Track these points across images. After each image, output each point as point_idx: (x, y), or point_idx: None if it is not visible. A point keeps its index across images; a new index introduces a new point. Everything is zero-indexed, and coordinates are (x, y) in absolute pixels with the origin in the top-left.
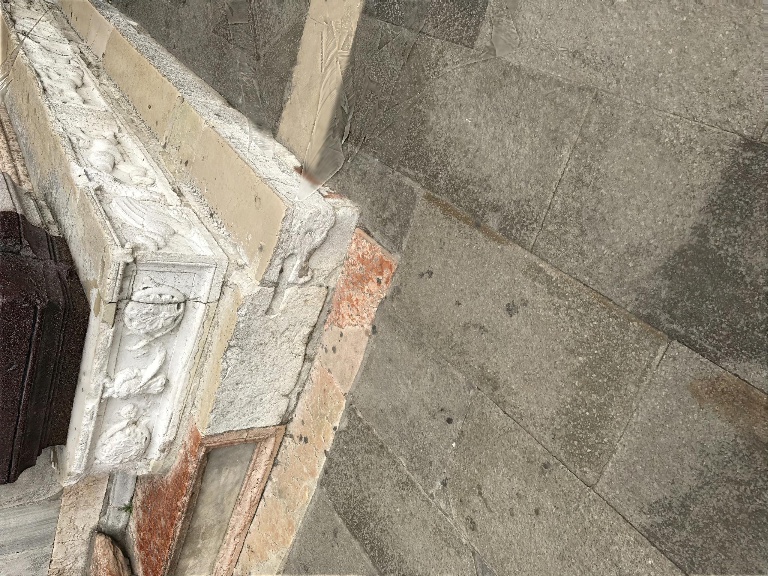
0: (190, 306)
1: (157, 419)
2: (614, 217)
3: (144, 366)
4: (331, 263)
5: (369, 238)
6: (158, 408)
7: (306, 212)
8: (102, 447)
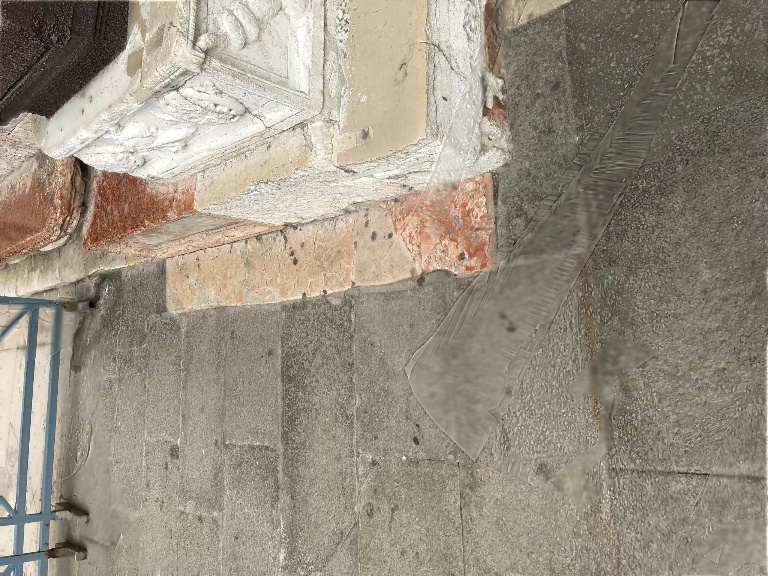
0: (248, 116)
1: (158, 158)
2: None
3: (165, 127)
4: None
5: (491, 203)
6: (163, 152)
7: None
8: (86, 155)
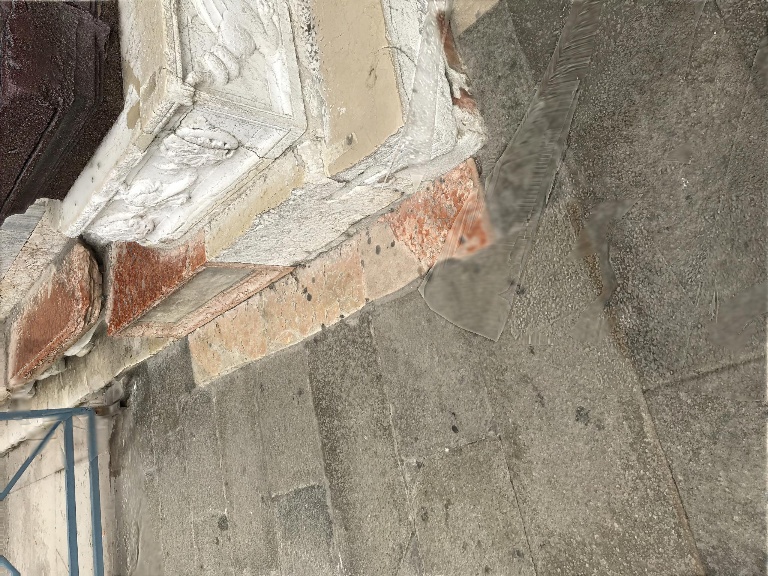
0: (242, 151)
1: (166, 219)
2: (759, 463)
3: (168, 181)
4: None
5: None
6: (170, 211)
7: None
8: (100, 227)
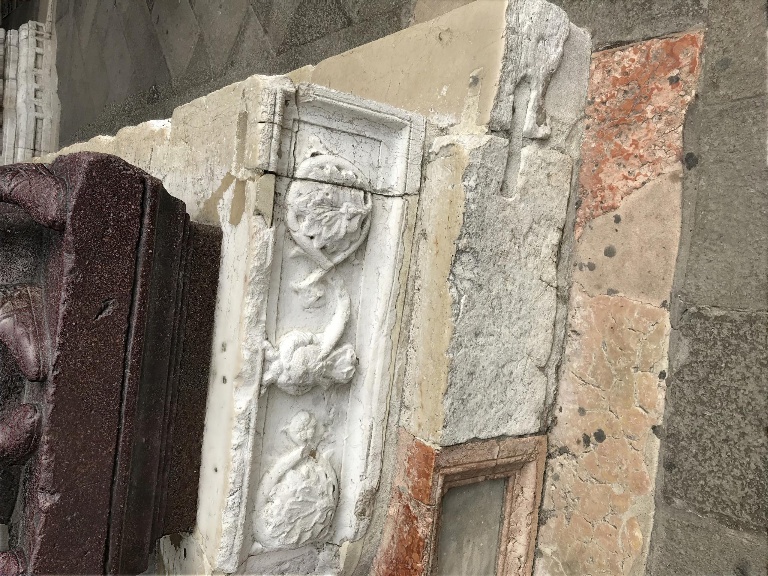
0: (378, 206)
1: (346, 447)
2: None
3: (319, 328)
4: (570, 112)
5: None
6: (345, 423)
7: (533, 3)
8: (265, 507)
